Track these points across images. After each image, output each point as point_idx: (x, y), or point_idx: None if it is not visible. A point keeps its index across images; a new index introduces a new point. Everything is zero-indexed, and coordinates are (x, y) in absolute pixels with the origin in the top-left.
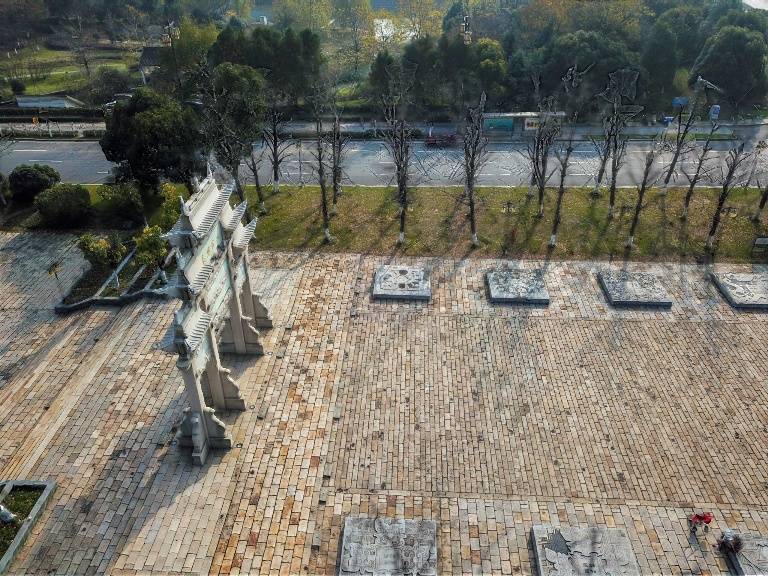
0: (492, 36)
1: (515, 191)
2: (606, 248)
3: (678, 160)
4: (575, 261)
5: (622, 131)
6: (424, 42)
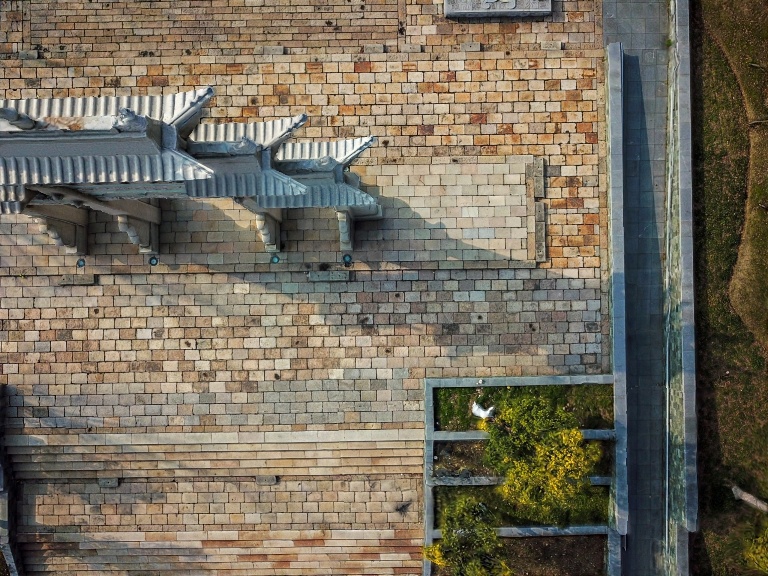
0: None
1: None
2: None
3: None
4: None
5: None
6: None
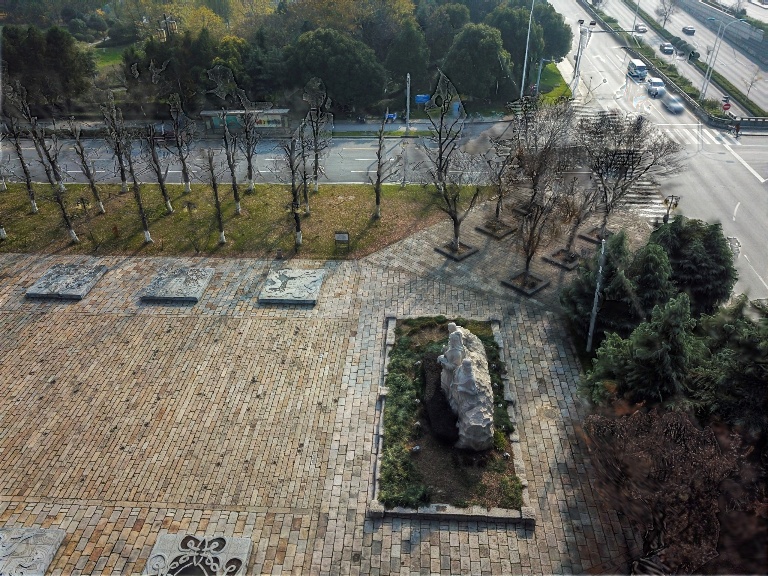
0: (242, 34)
1: (178, 188)
2: (200, 244)
3: (318, 157)
4: (157, 257)
5: (356, 128)
6: (168, 40)
